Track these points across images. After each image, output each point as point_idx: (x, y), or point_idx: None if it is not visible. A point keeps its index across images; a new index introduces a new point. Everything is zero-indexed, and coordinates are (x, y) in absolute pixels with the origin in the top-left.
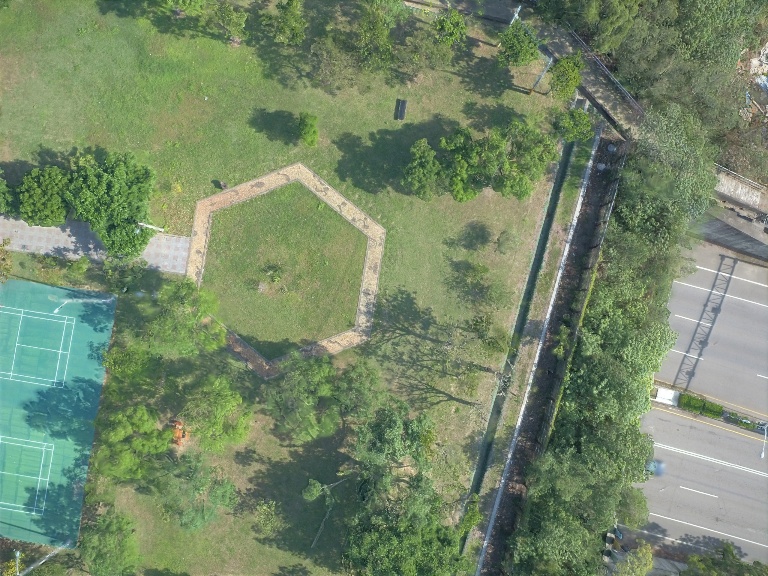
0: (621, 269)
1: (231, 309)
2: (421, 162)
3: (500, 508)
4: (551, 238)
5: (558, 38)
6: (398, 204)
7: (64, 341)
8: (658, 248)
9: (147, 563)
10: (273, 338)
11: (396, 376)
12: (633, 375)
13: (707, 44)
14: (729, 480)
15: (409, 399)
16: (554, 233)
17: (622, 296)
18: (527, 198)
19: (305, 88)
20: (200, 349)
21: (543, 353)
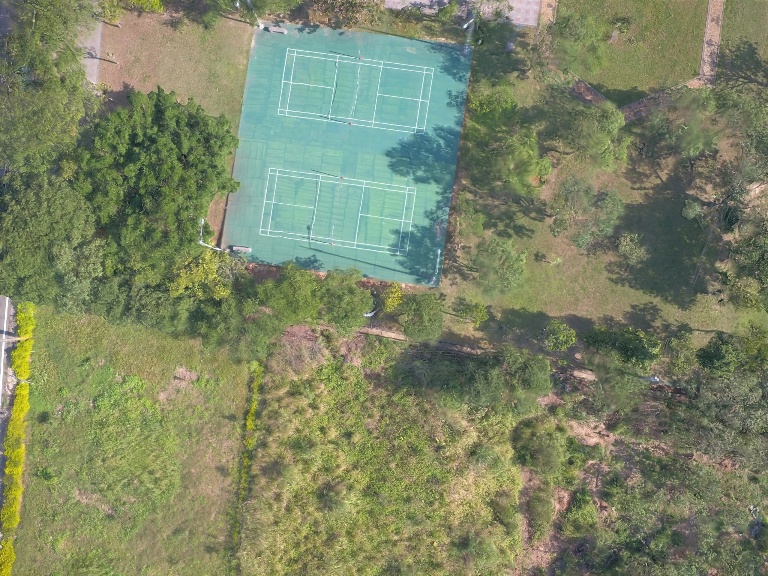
0: None
1: (582, 59)
2: None
3: None
4: None
5: None
6: None
7: (424, 90)
8: None
9: (504, 303)
10: (623, 86)
11: None
12: None
13: None
14: None
15: None
16: None
17: None
18: None
19: None
20: (554, 97)
21: None
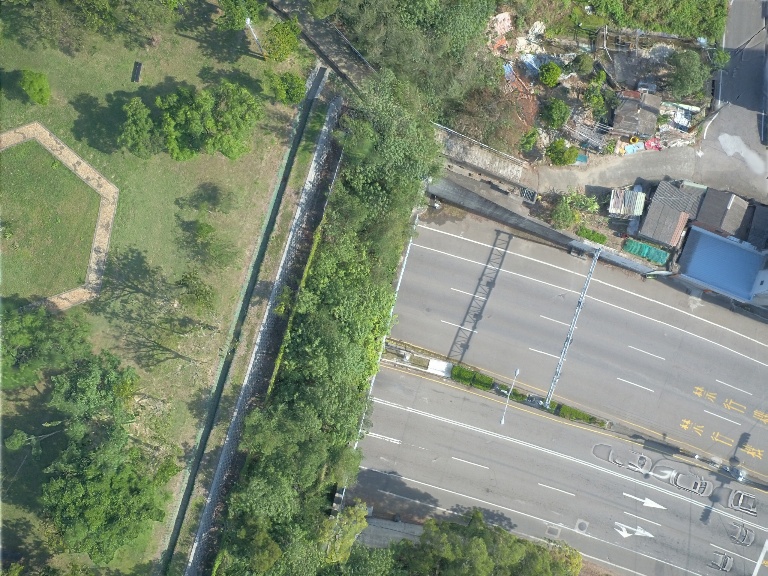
0: (344, 232)
1: None
2: (135, 120)
3: (232, 467)
4: (284, 201)
5: (299, 7)
6: (132, 164)
7: None
8: (378, 211)
9: None
10: (3, 293)
11: (124, 333)
12: (352, 335)
13: (436, 15)
14: (500, 452)
15: (136, 356)
16: (287, 196)
17: (342, 258)
18: (260, 161)
19: (44, 49)
20: None
21: (280, 315)
